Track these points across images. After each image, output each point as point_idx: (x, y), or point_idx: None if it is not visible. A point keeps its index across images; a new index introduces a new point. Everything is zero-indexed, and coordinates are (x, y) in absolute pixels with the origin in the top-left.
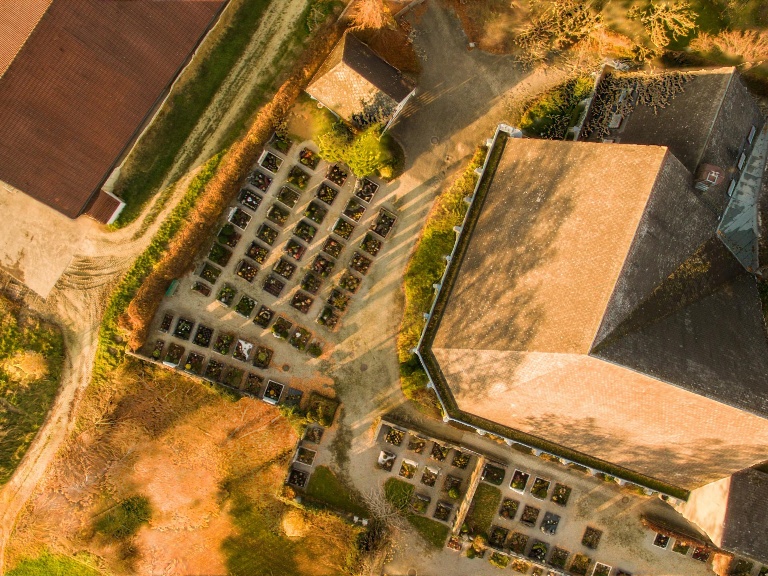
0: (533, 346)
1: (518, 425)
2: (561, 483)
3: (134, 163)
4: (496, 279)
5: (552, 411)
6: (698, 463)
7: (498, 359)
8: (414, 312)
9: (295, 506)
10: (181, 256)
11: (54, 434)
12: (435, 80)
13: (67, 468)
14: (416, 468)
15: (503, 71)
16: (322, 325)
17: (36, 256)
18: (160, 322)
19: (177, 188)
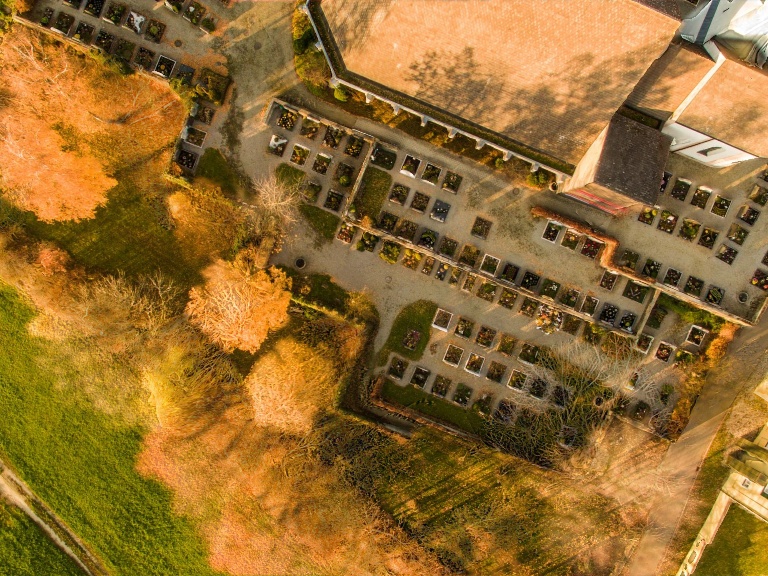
0: None
1: (405, 84)
2: (452, 171)
3: None
4: None
5: (433, 46)
6: (577, 108)
7: None
8: None
9: (182, 186)
10: None
11: None
12: None
13: None
14: (307, 151)
15: None
16: None
17: None
18: None
19: None
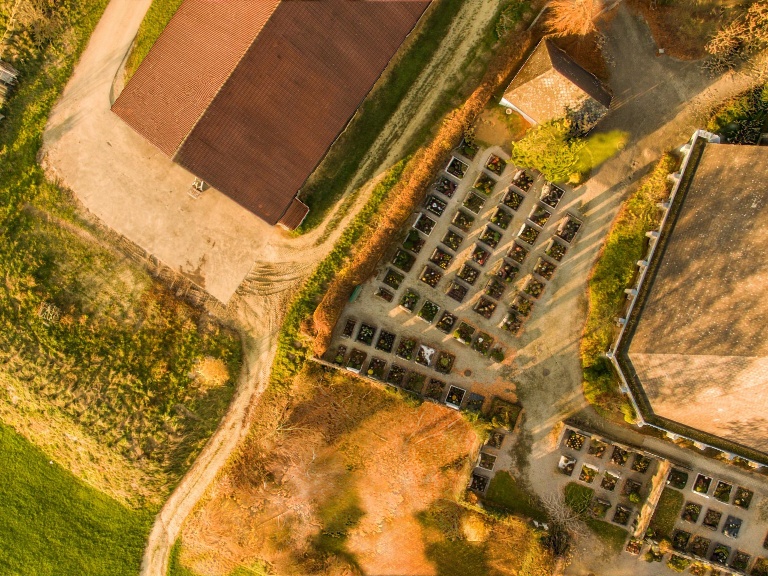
0: (764, 351)
1: (715, 429)
2: (743, 487)
3: (322, 169)
4: (706, 284)
5: (763, 416)
6: None
7: (716, 364)
8: (599, 317)
9: (476, 511)
10: (369, 262)
11: (227, 440)
12: (623, 86)
13: (242, 474)
14: (598, 472)
15: (690, 77)
16: (505, 330)
17: (217, 262)
18: (342, 328)
19: (361, 194)
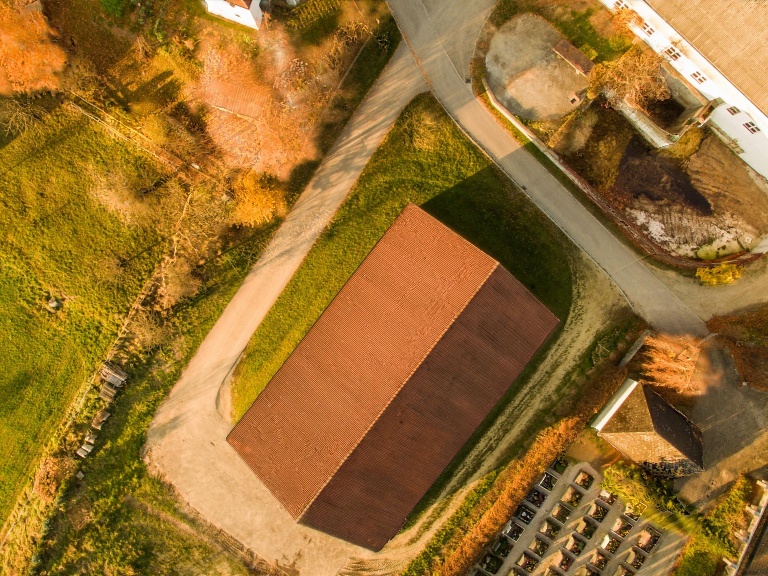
0: None
1: None
2: None
3: None
4: None
5: None
6: None
7: None
8: None
9: None
10: (462, 571)
11: None
12: (707, 413)
13: None
14: None
15: None
16: None
17: (313, 557)
18: None
19: (454, 499)
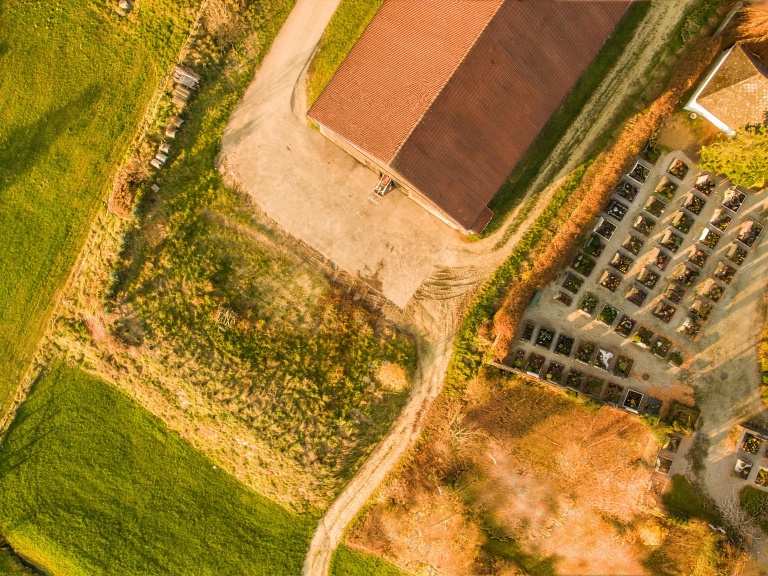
0: None
1: None
2: None
3: None
4: None
5: None
6: None
7: None
8: None
9: (654, 515)
10: (554, 266)
11: (396, 444)
12: None
13: (413, 478)
14: None
15: None
16: (683, 334)
17: (396, 267)
18: (521, 332)
19: (540, 198)
